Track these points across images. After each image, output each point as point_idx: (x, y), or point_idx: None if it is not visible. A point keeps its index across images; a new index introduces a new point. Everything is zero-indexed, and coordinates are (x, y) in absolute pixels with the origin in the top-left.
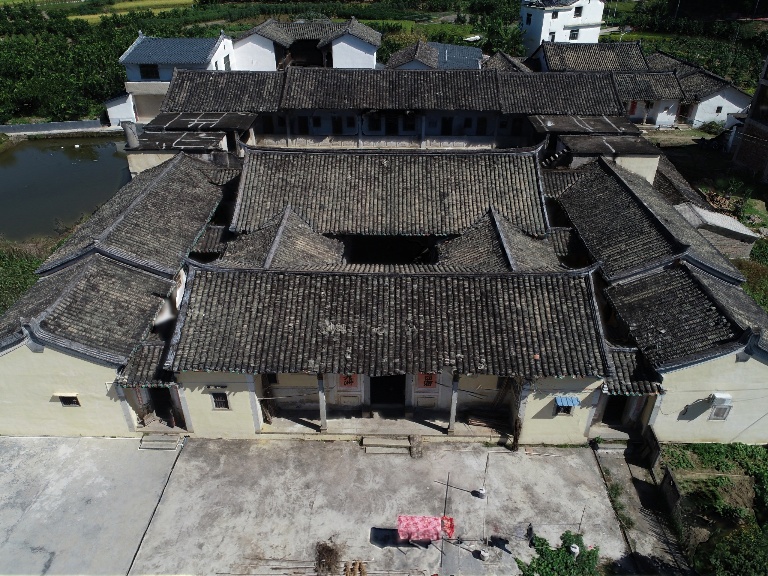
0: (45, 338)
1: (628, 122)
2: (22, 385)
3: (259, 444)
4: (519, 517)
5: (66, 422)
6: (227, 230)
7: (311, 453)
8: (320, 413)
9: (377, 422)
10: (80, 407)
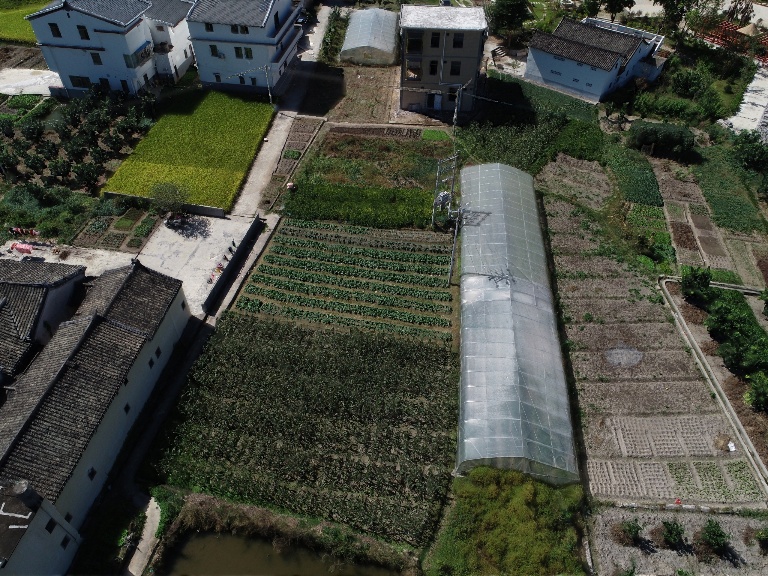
0: None
1: None
2: None
3: None
4: None
5: None
6: (5, 385)
7: None
8: None
9: None
10: None
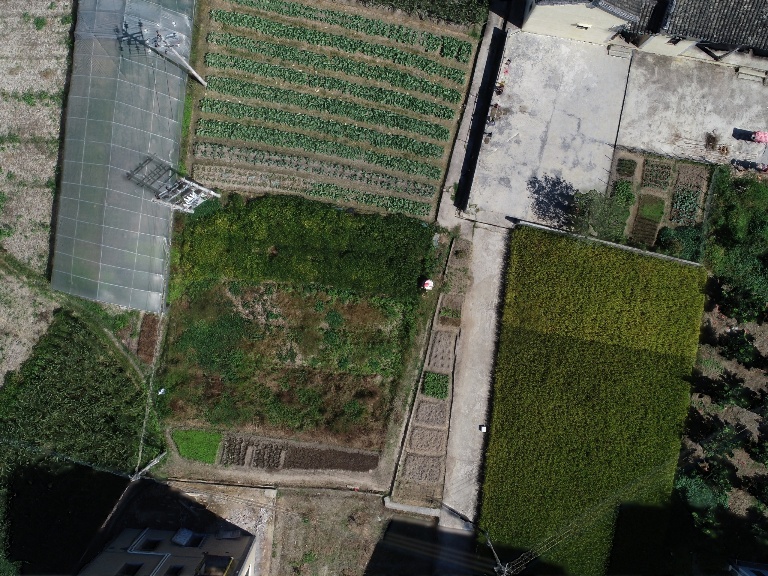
0: (603, 5)
1: None
2: (562, 17)
3: (677, 61)
4: None
5: (569, 33)
6: None
7: (707, 73)
8: (727, 55)
9: (751, 57)
10: (586, 30)
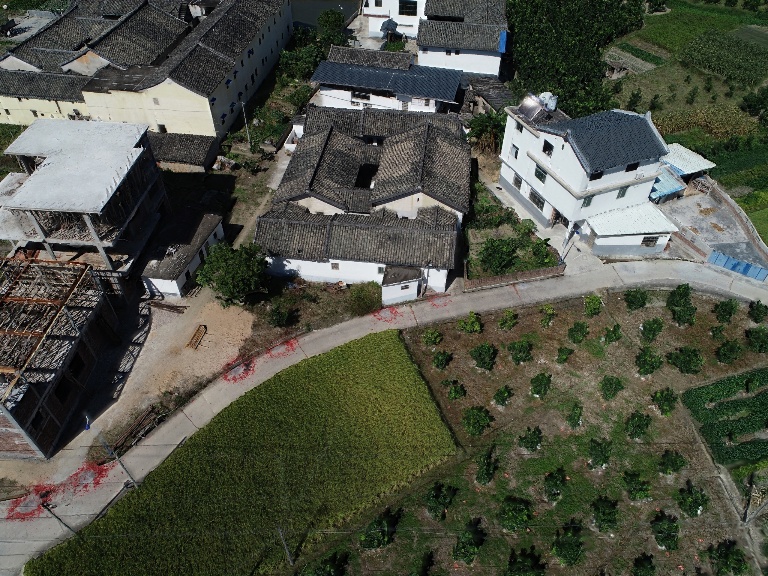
0: None
1: (126, 89)
2: None
3: None
4: None
5: None
6: None
7: None
8: None
9: None
10: None
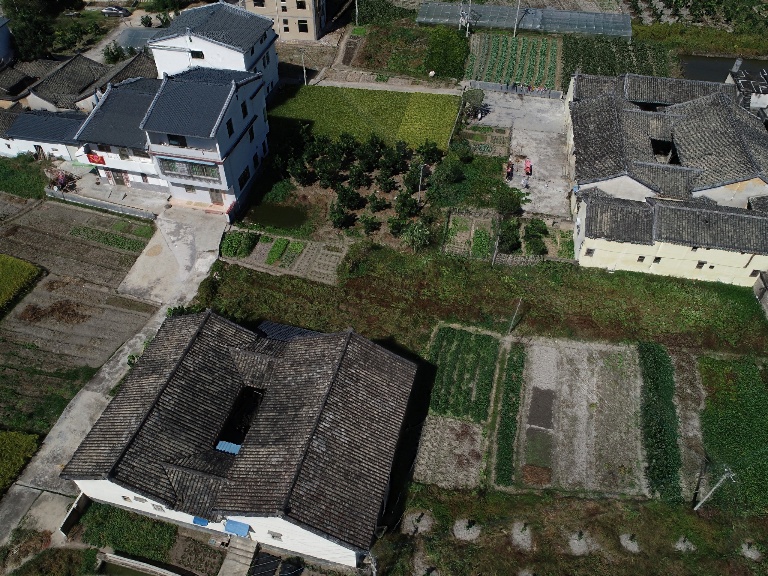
0: None
1: None
2: None
3: (565, 147)
4: (537, 193)
5: None
6: None
7: None
8: None
9: None
10: None
